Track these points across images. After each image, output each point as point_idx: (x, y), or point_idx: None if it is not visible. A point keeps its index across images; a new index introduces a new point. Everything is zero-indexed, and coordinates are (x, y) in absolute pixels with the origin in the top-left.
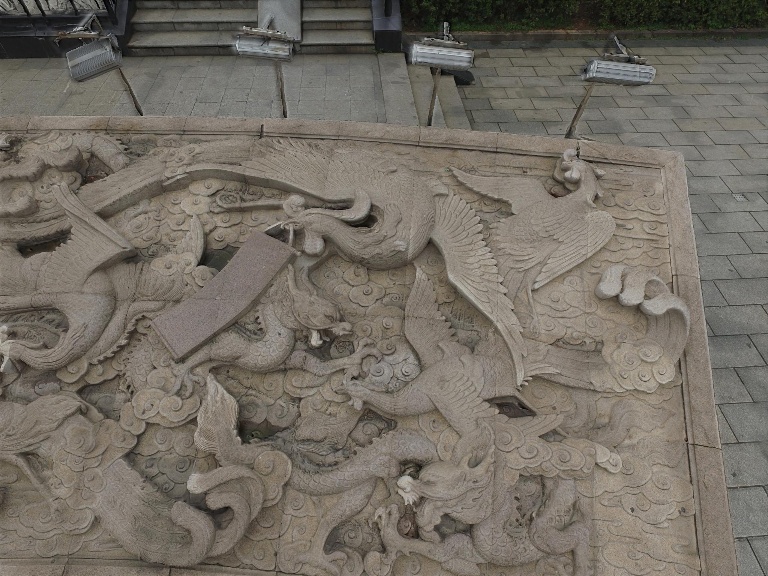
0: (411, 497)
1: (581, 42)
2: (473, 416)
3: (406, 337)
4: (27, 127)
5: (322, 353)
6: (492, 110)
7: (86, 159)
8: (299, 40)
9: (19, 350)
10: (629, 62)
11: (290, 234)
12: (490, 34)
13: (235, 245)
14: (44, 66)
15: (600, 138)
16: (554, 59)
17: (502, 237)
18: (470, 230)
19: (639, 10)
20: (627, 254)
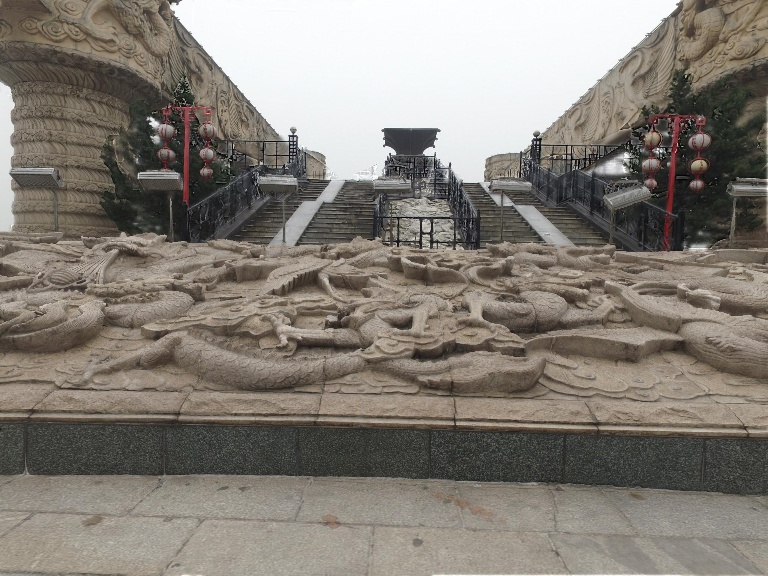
0: None
1: None
2: None
3: None
4: None
5: None
6: None
7: None
8: None
9: (718, 292)
10: None
11: None
12: None
13: None
14: None
15: None
16: None
17: None
18: None
19: None
20: None
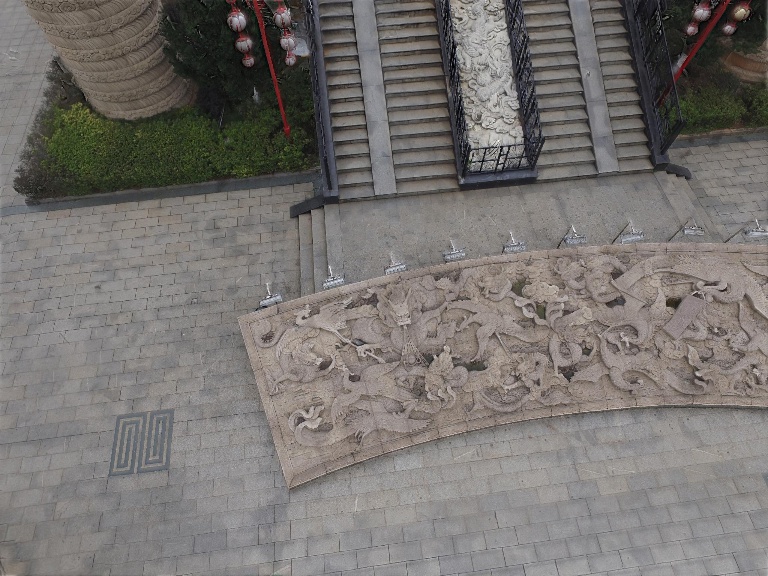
0: (759, 374)
1: (739, 137)
2: None
3: (742, 328)
4: (578, 253)
5: (715, 334)
6: (708, 197)
7: None
8: None
9: (631, 340)
10: None
11: None
12: (689, 136)
13: (673, 297)
14: (499, 194)
15: (765, 213)
16: (728, 153)
17: (767, 291)
18: (758, 289)
19: None
20: None
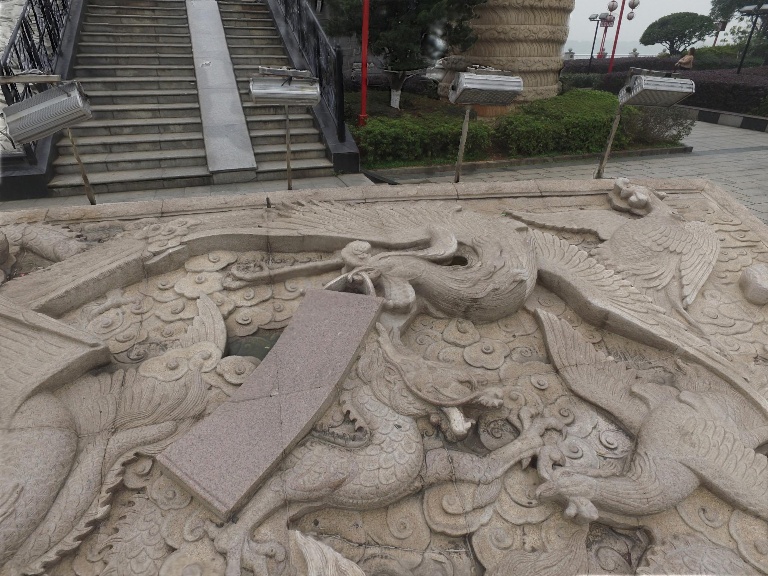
0: None
1: (501, 168)
2: (761, 479)
3: (579, 394)
4: None
5: (468, 447)
6: None
7: (12, 253)
8: (255, 167)
9: None
10: (666, 77)
11: (367, 282)
12: (423, 168)
13: (270, 326)
14: None
15: None
16: (488, 179)
17: (612, 260)
18: (577, 256)
19: (538, 141)
20: (739, 262)
